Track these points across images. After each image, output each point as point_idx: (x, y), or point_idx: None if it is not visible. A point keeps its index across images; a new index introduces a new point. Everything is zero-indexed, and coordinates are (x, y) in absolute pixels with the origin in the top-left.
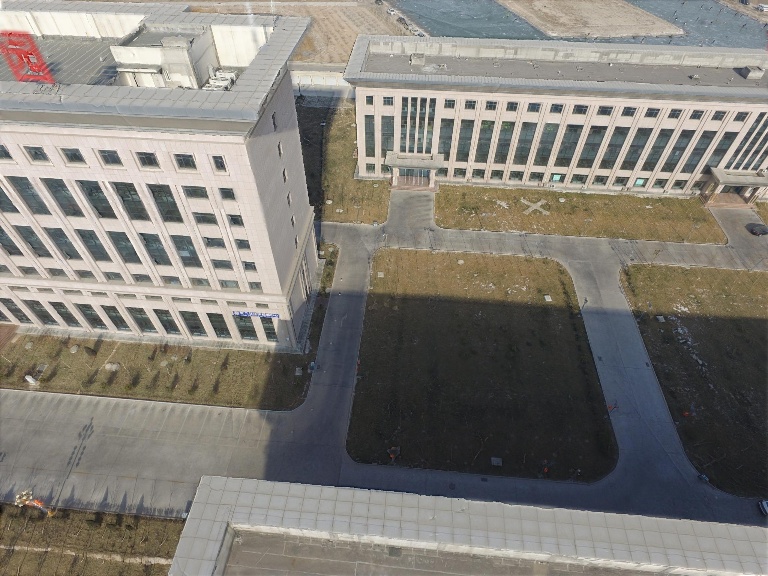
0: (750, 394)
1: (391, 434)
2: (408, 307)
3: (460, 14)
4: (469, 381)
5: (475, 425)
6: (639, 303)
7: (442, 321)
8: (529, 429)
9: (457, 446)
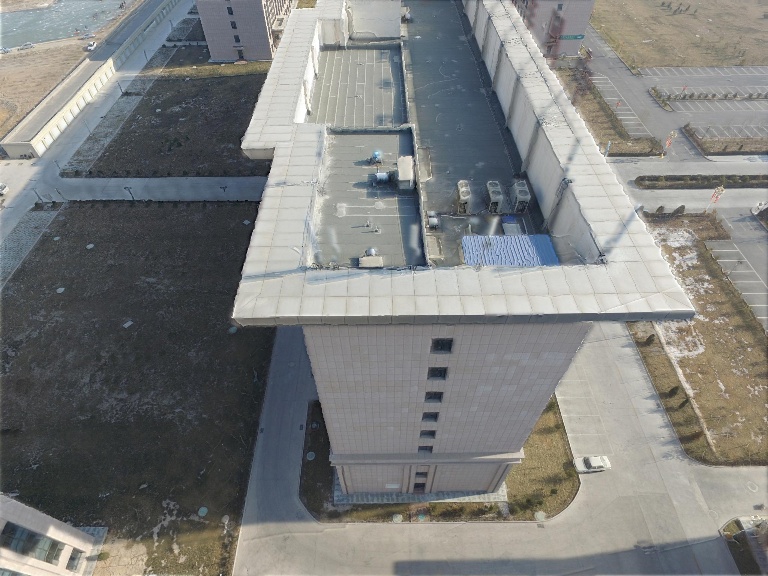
0: None
1: None
2: None
3: None
4: None
5: None
6: None
7: None
8: None
9: None
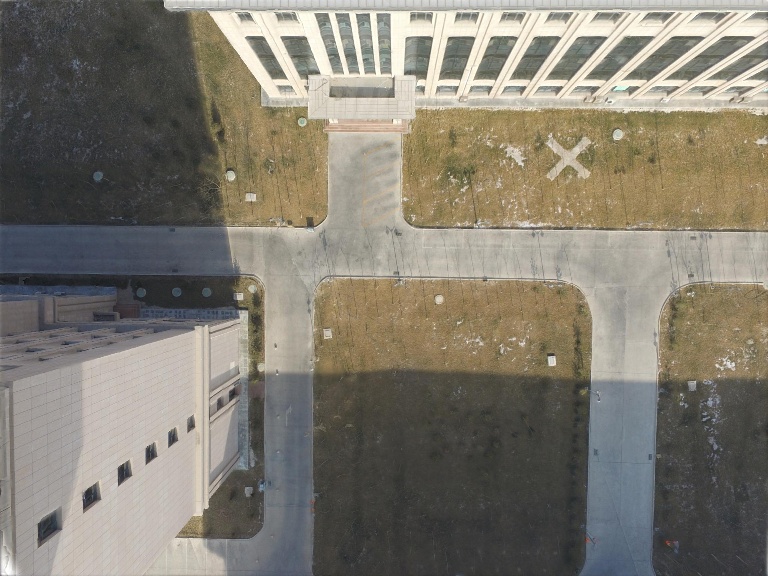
0: (754, 486)
1: (356, 557)
2: (367, 387)
3: None
4: (439, 490)
5: (442, 541)
6: (673, 361)
7: (411, 406)
8: (498, 543)
9: (423, 566)
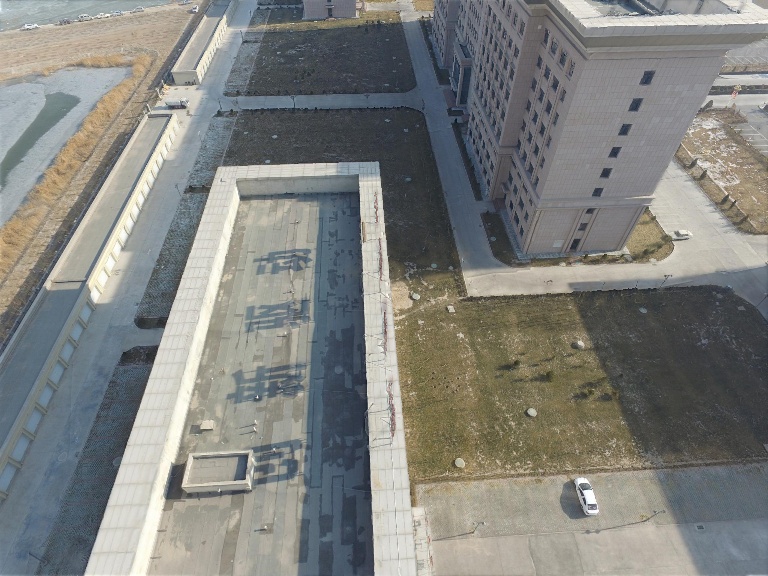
0: None
1: None
2: None
3: (52, 6)
4: None
5: None
6: None
7: None
8: None
9: None
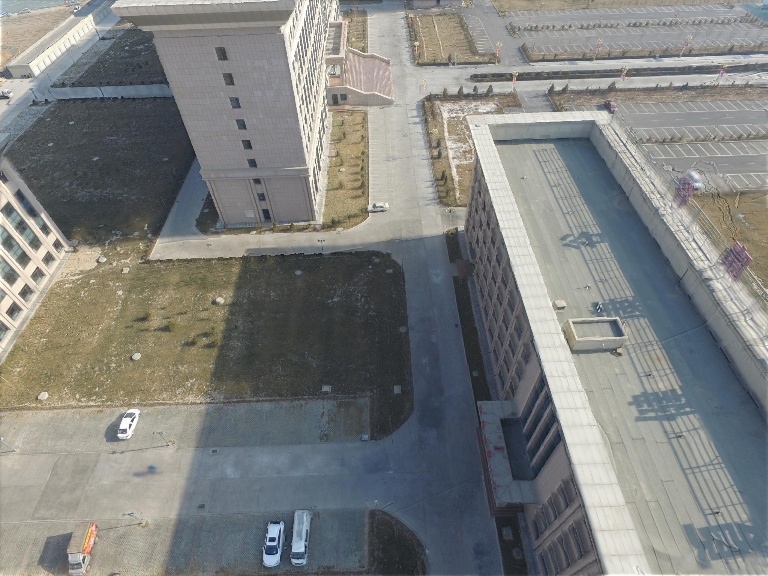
0: None
1: None
2: None
3: None
4: None
5: None
6: None
7: None
8: None
9: None
